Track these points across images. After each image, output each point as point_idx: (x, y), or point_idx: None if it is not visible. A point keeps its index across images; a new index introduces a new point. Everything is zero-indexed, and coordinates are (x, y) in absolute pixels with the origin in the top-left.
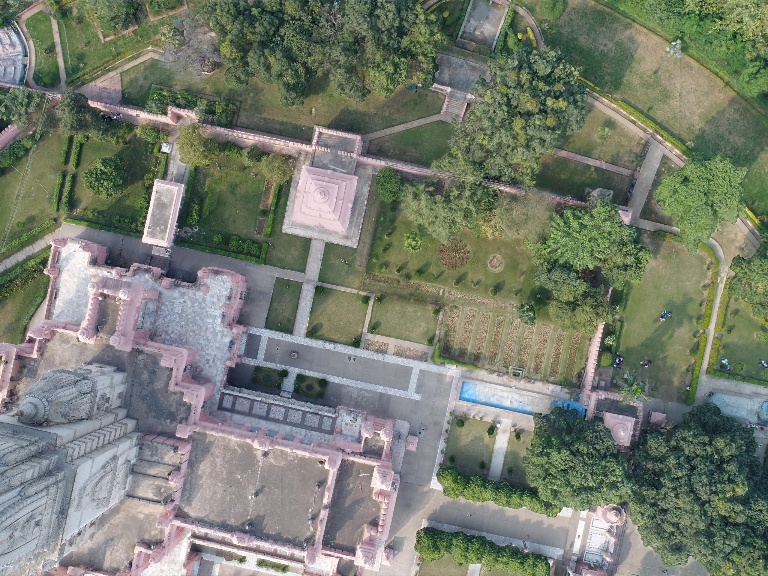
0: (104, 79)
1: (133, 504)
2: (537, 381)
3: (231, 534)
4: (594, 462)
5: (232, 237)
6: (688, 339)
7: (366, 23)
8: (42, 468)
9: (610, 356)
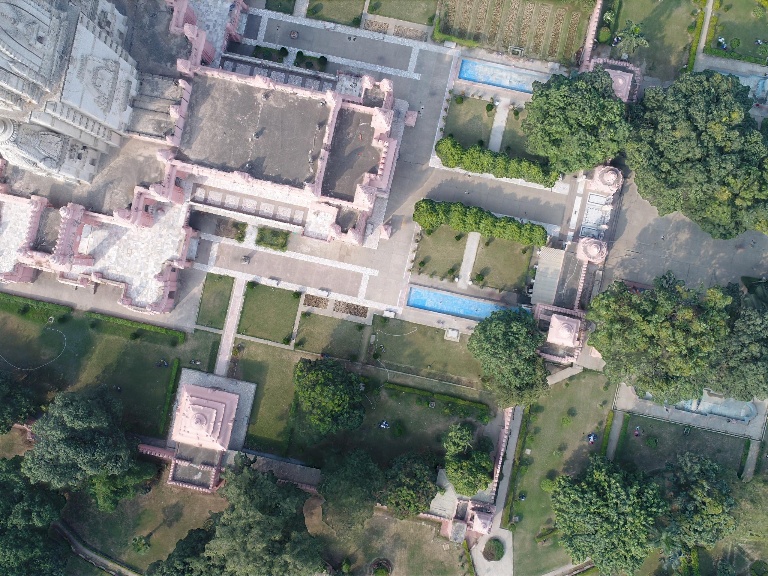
0: None
1: (133, 147)
2: (536, 60)
3: (231, 172)
4: (592, 98)
5: None
6: (686, 19)
7: None
8: None
9: (609, 30)
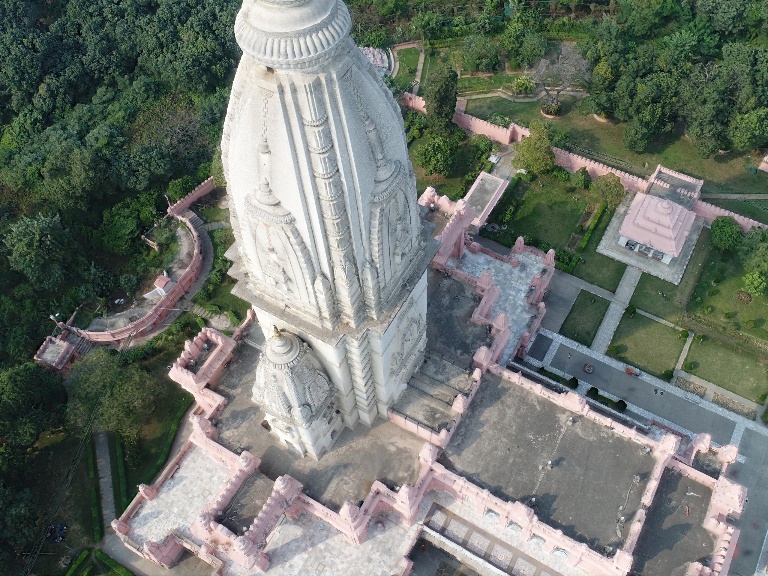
0: None
1: (387, 431)
2: None
3: (509, 501)
4: None
5: (543, 241)
6: None
7: (750, 67)
8: None
9: None
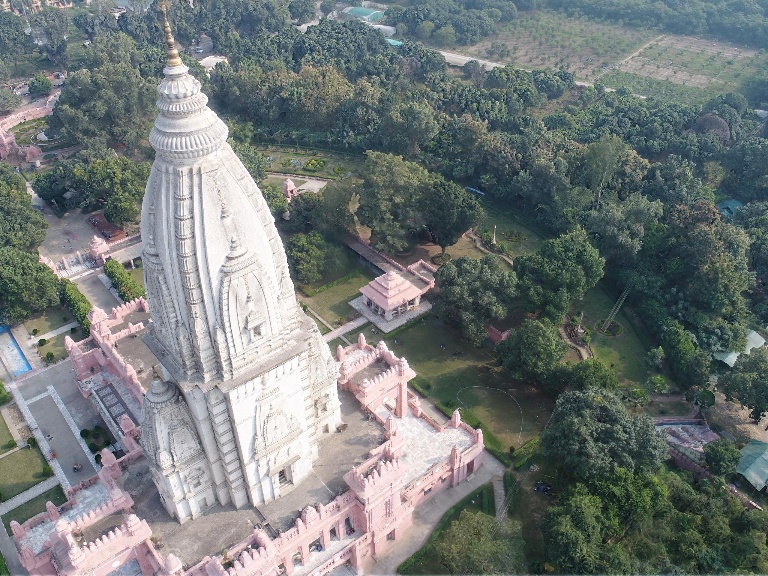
0: None
1: None
2: None
3: None
4: None
5: None
6: None
7: None
8: None
9: None
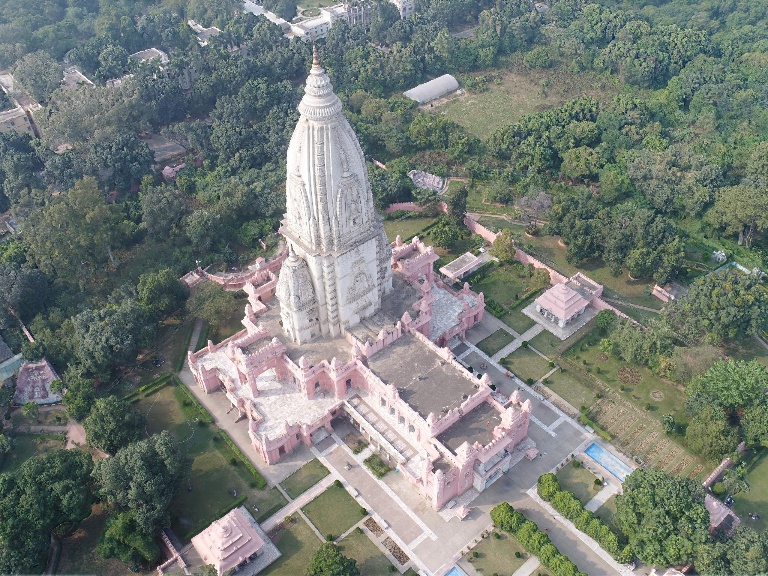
0: (472, 214)
1: (342, 343)
2: None
3: None
4: None
5: None
6: None
7: None
8: (371, 216)
9: None
